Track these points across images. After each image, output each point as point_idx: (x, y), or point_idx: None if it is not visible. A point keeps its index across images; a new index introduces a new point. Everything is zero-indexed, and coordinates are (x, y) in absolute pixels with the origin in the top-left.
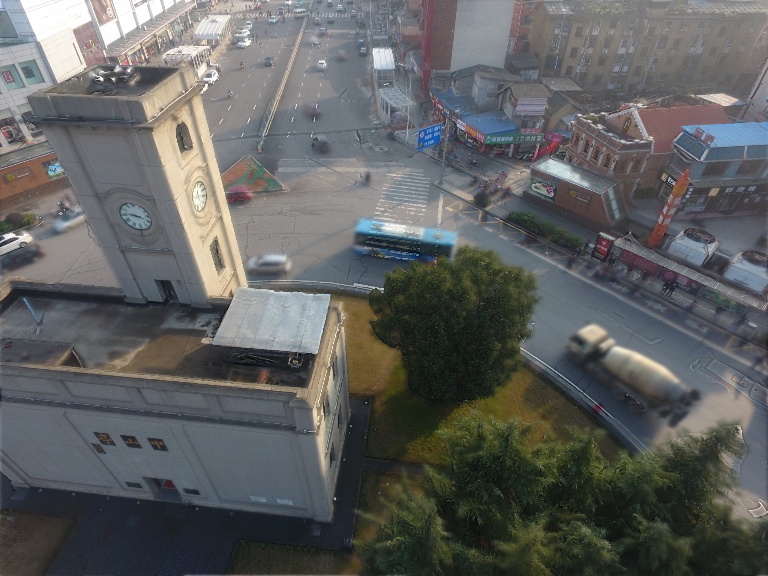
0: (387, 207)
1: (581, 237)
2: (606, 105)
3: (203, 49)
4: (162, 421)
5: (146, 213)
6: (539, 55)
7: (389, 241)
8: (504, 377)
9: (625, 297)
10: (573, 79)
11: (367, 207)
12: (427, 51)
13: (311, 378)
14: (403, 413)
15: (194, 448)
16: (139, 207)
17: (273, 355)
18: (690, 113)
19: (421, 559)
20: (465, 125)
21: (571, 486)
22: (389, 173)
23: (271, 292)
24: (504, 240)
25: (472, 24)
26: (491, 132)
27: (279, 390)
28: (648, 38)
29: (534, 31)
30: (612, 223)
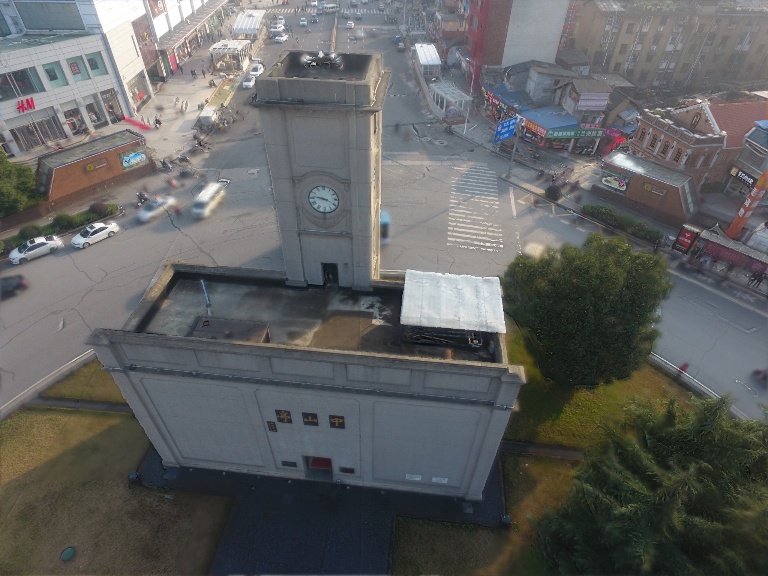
0: (460, 199)
1: (661, 229)
2: (659, 101)
3: (246, 43)
4: (355, 398)
5: (334, 196)
6: (587, 51)
7: (470, 232)
8: (643, 361)
9: (713, 288)
10: (622, 75)
11: (441, 199)
12: (479, 46)
13: (502, 356)
14: (526, 397)
15: (373, 425)
16: (329, 190)
17: (449, 335)
18: (758, 109)
19: (654, 525)
20: (524, 120)
21: (765, 459)
22: (454, 166)
23: (440, 275)
24: (582, 232)
25: (526, 20)
26: (553, 127)
27: (490, 366)
28: (697, 35)
29: (581, 27)
30: (688, 216)
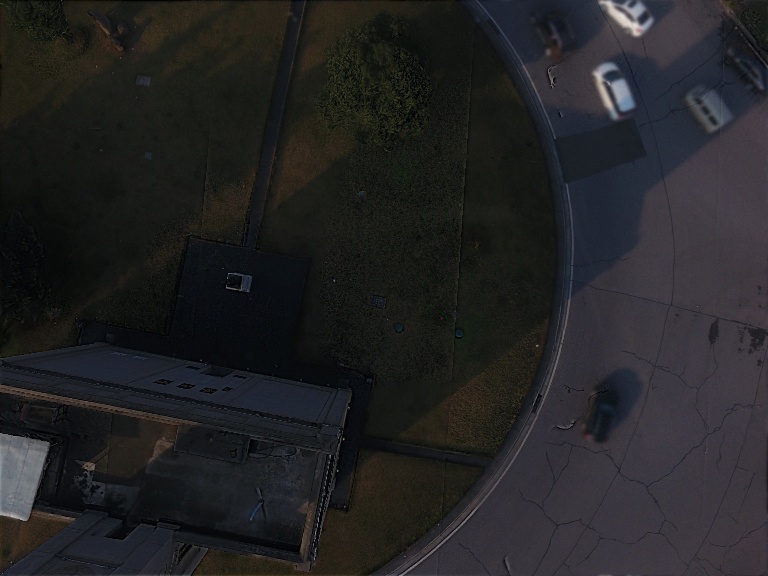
0: None
1: None
2: None
3: None
4: None
5: None
6: None
7: None
8: None
9: None
10: None
11: None
12: None
13: None
14: None
15: None
16: None
17: None
18: None
19: None
20: None
21: None
22: None
23: None
24: None
25: None
26: None
27: None
28: None
29: None
30: None
